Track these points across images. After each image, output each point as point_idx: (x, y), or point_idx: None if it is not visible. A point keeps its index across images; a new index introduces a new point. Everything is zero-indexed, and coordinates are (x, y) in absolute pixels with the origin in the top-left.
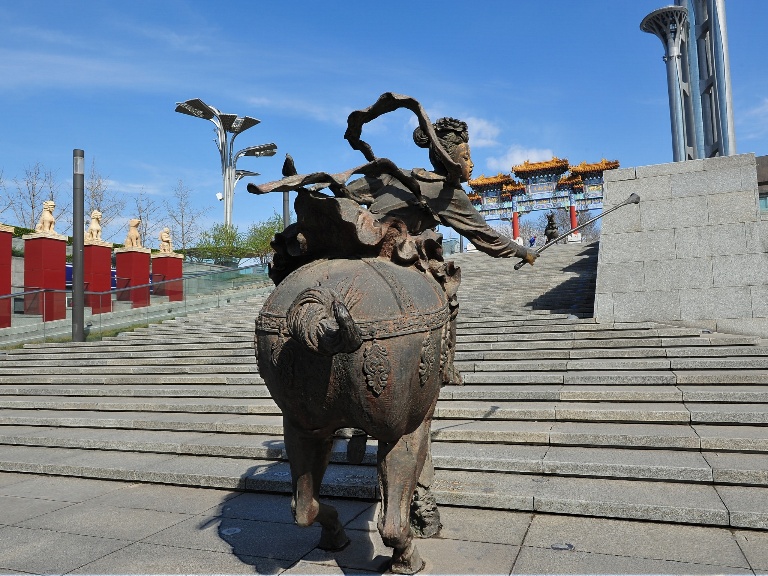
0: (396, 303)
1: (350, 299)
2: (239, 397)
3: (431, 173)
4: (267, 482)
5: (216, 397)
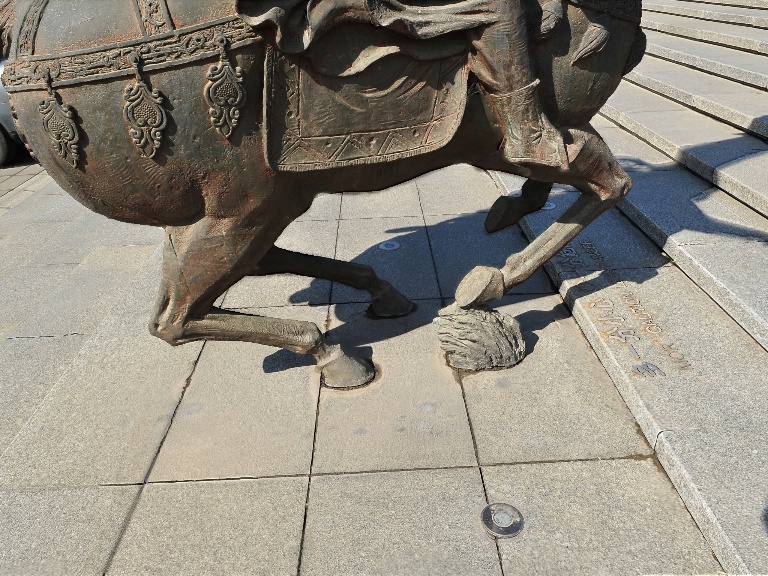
0: None
1: (3, 26)
2: (731, 78)
3: None
4: None
5: (710, 72)
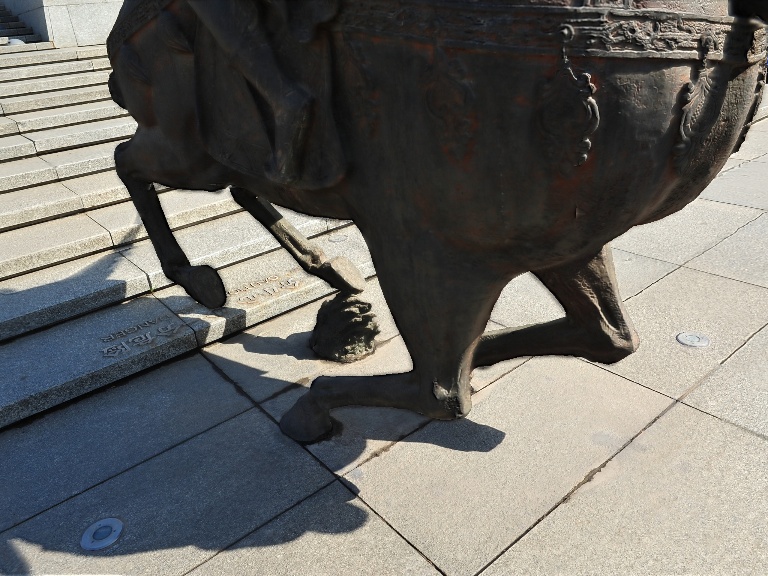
0: None
1: None
2: None
3: None
4: None
5: None
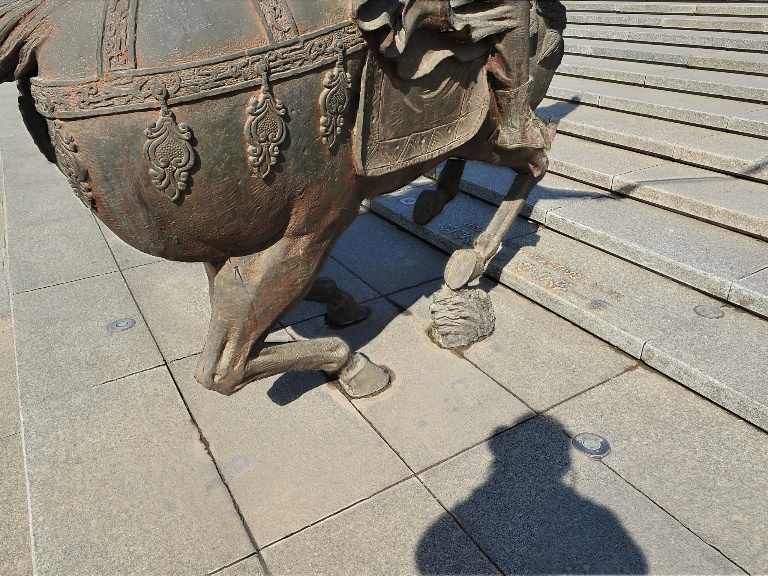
0: (96, 48)
1: (25, 38)
2: None
3: None
4: (385, 208)
5: None
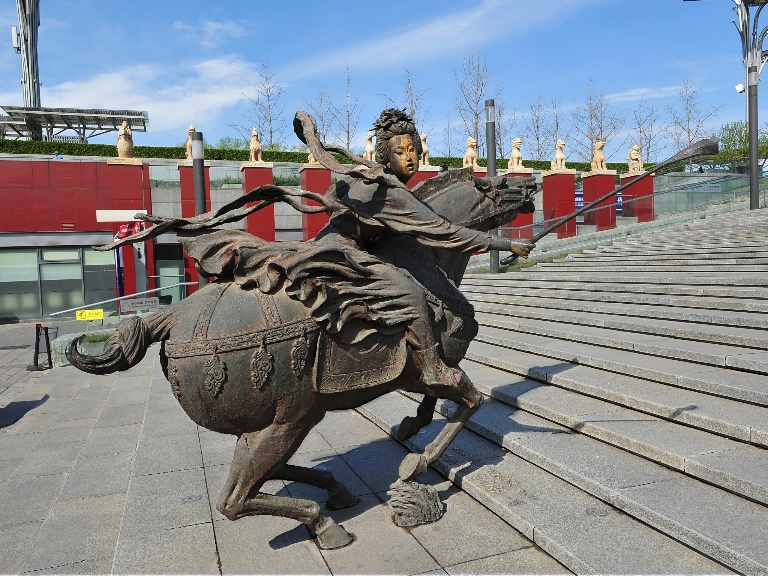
0: None
1: (167, 324)
2: (508, 347)
3: (380, 172)
4: None
5: (494, 344)
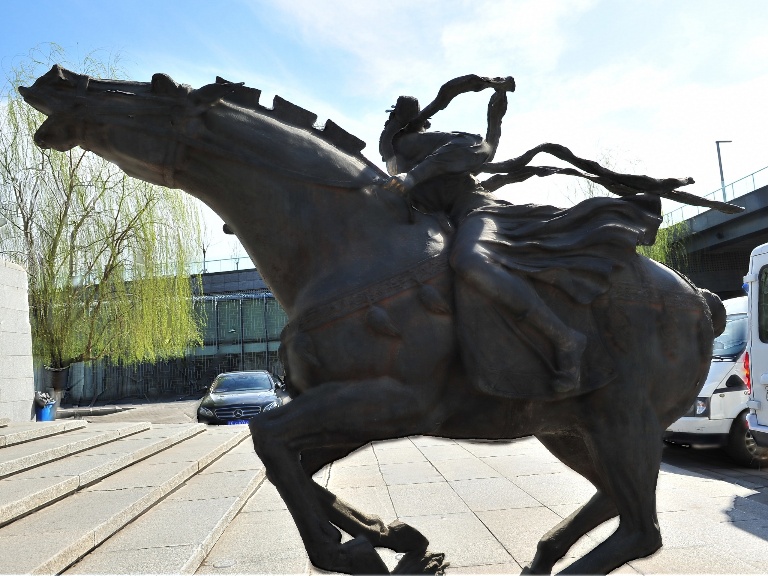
0: None
1: None
2: None
3: None
4: None
5: None
